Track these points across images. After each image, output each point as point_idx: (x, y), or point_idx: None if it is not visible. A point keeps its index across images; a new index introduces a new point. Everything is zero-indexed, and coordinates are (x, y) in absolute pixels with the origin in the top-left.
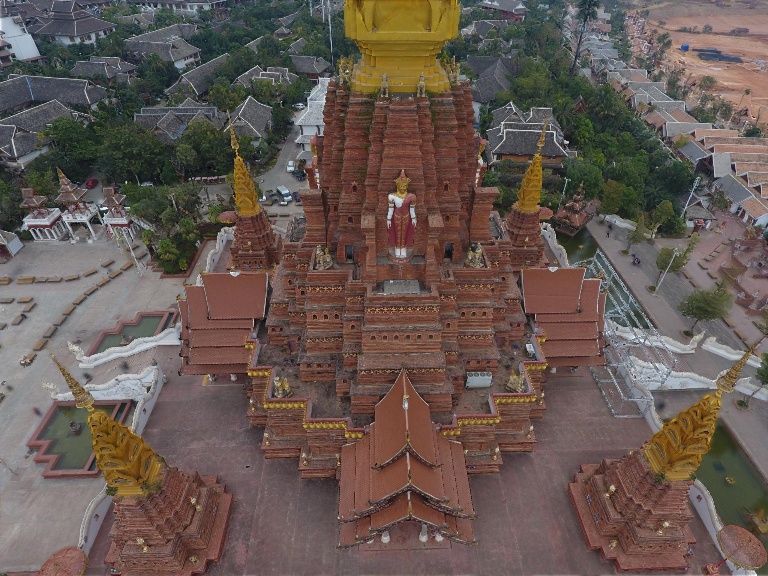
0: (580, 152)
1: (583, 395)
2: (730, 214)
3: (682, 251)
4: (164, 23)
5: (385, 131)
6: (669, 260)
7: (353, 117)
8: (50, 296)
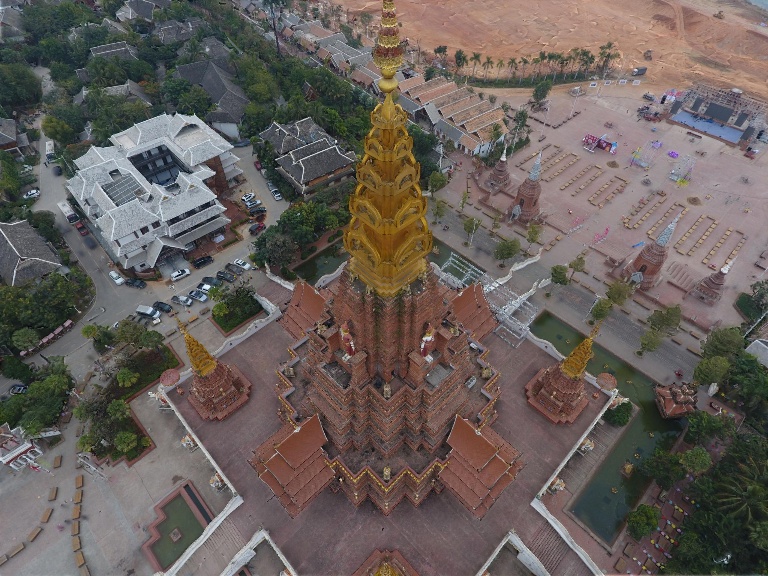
0: (345, 143)
1: (495, 346)
2: (456, 150)
3: (460, 204)
4: None
5: (416, 311)
6: (473, 227)
7: (390, 311)
8: (35, 566)
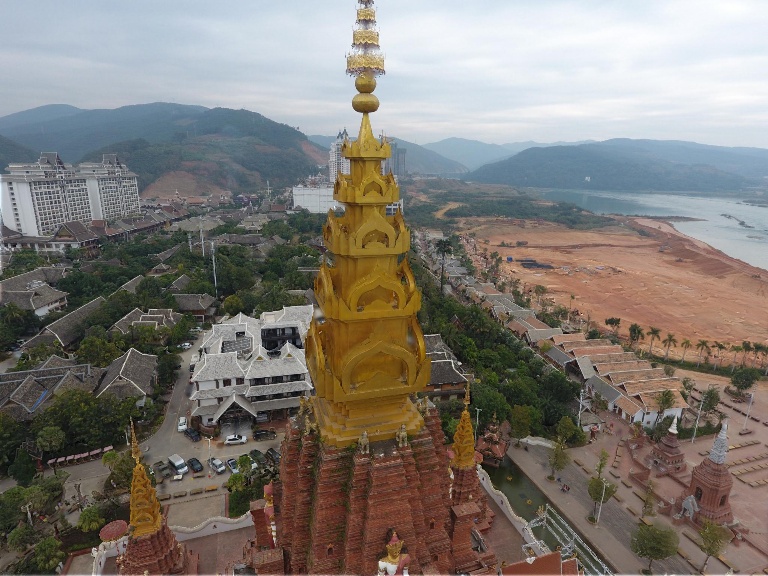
0: (472, 370)
1: None
2: (610, 412)
3: (597, 466)
4: (24, 266)
5: (370, 491)
6: (601, 491)
7: (328, 475)
8: None
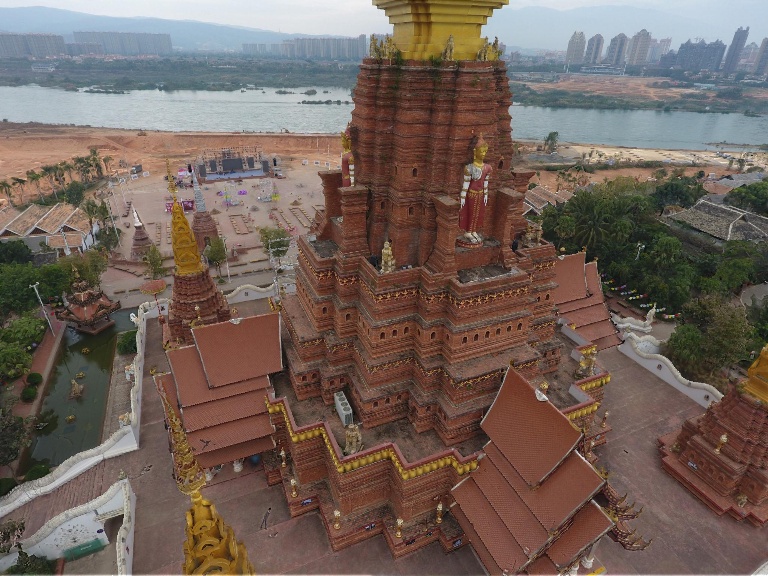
0: None
1: None
2: None
3: None
4: None
5: None
6: (223, 248)
7: None
8: None
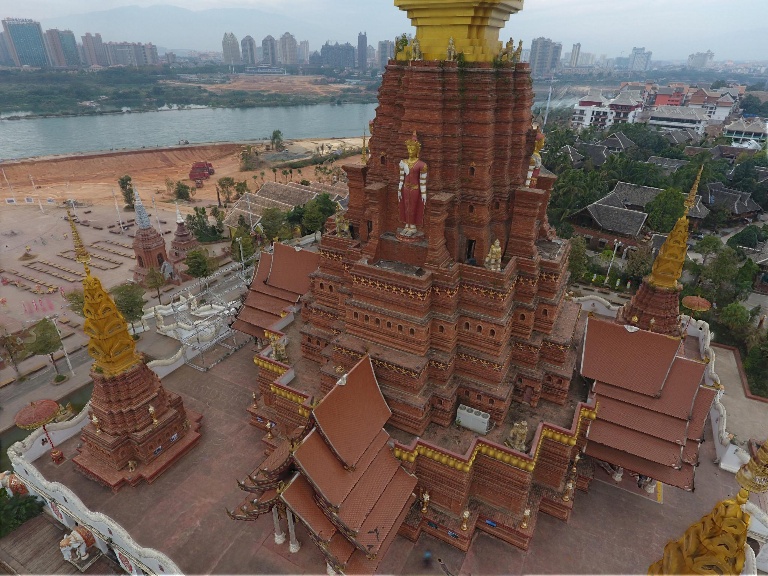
0: None
1: None
2: None
3: None
4: None
5: None
6: (55, 332)
7: None
8: None
